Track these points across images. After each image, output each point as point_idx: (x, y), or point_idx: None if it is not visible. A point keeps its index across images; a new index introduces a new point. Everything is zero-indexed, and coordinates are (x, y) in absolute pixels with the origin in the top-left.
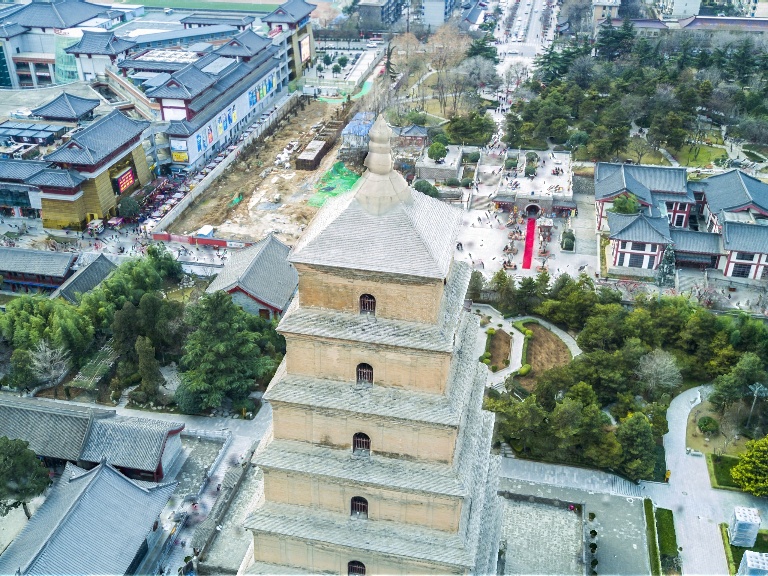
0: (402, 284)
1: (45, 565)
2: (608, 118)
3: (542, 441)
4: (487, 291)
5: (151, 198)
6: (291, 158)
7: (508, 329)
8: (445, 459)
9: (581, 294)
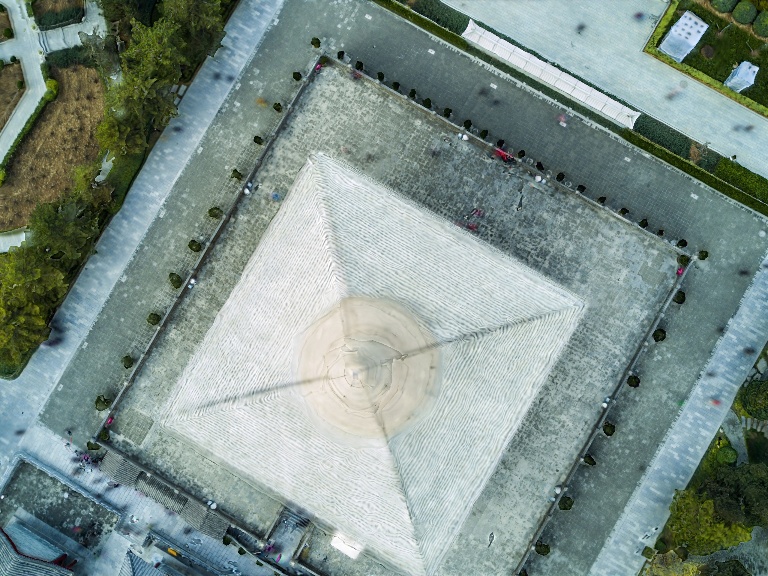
0: None
1: None
2: None
3: (196, 46)
4: None
5: None
6: None
7: None
8: None
9: None
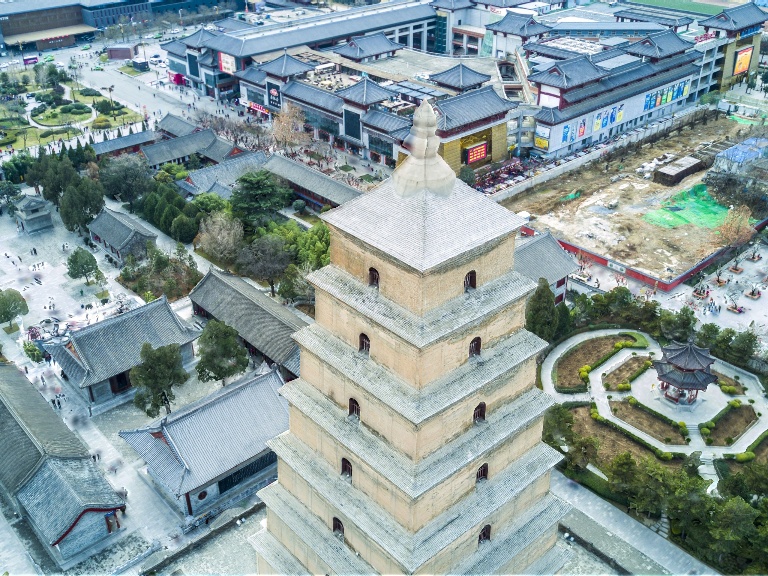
0: (397, 267)
1: (189, 425)
2: None
3: (697, 533)
4: (758, 360)
5: (496, 175)
6: (656, 169)
7: (759, 408)
8: (411, 455)
9: None
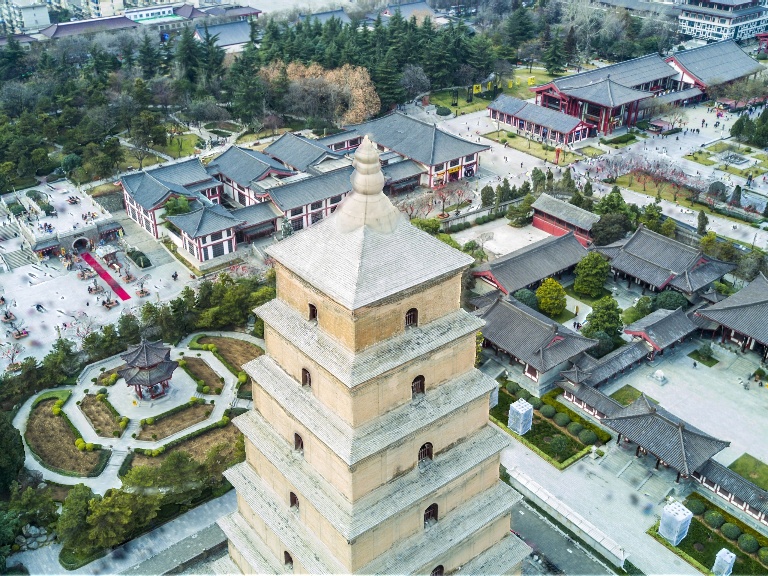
0: (438, 284)
1: None
2: (85, 135)
3: None
4: (143, 330)
5: None
6: None
7: (191, 353)
8: (485, 423)
9: (232, 292)
